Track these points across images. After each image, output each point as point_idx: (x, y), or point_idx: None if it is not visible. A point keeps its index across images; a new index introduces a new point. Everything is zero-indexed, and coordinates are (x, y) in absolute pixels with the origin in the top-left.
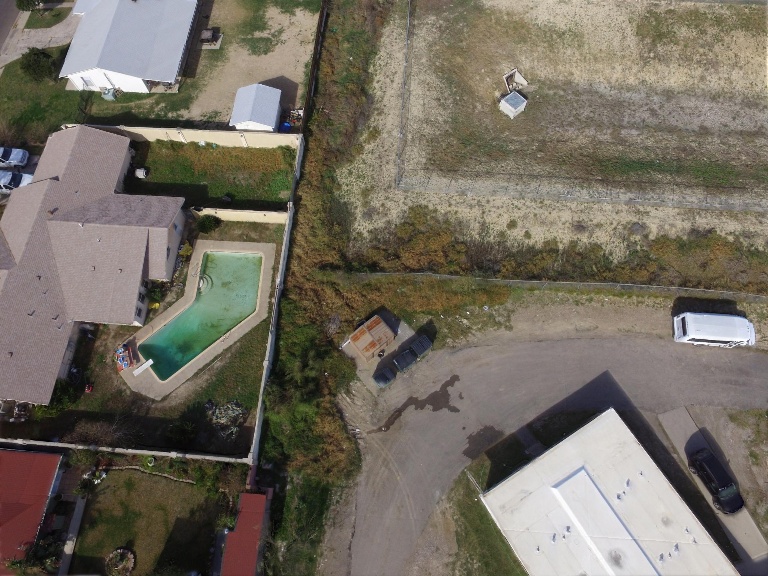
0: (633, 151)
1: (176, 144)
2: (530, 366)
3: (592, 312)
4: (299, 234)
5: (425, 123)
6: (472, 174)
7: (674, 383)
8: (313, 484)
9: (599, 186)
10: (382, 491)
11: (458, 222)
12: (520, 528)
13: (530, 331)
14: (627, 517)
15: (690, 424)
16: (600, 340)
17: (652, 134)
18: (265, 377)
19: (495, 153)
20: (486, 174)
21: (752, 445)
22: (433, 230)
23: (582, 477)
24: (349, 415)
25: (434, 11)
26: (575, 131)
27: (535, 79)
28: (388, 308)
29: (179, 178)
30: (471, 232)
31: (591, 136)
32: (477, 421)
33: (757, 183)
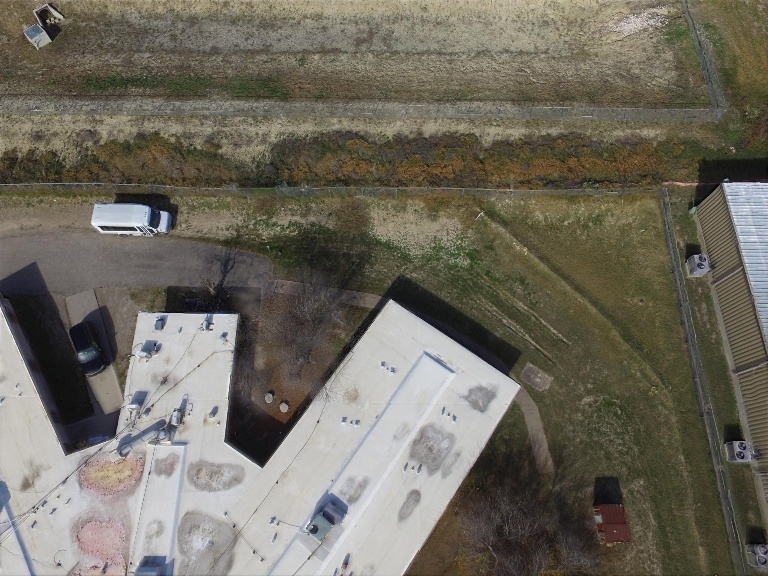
0: (129, 71)
1: None
2: None
3: (40, 212)
4: None
5: None
6: None
7: (92, 270)
8: None
9: (67, 100)
10: None
11: None
12: None
13: None
14: None
15: (92, 304)
16: (39, 236)
17: (162, 56)
18: None
19: None
20: None
21: None
22: None
23: None
24: None
25: None
26: (91, 57)
27: (71, 13)
28: None
29: None
30: None
31: (104, 61)
32: None
33: (220, 91)
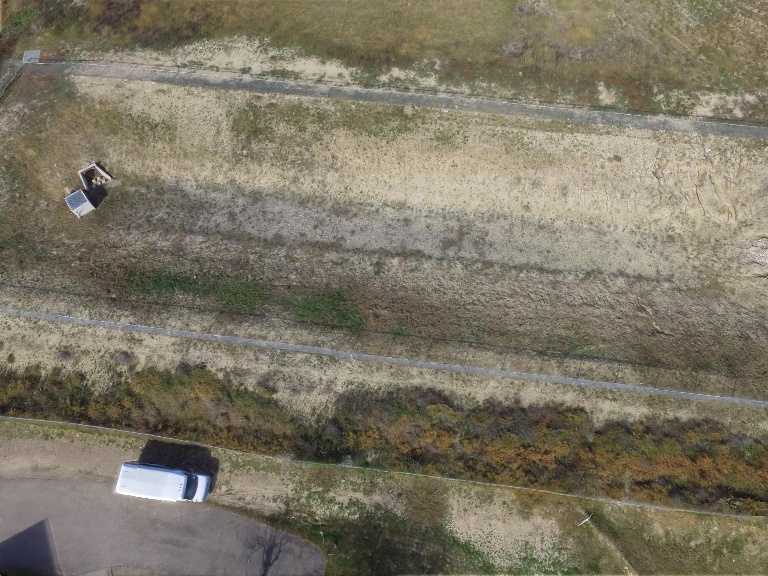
0: (179, 263)
1: None
2: None
3: (59, 449)
4: None
5: None
6: None
7: (111, 539)
8: None
9: (104, 307)
10: None
11: None
12: None
13: None
14: None
15: None
16: (55, 482)
17: (217, 242)
18: None
19: (29, 260)
20: None
21: None
22: None
23: None
24: None
25: (25, 97)
26: (137, 235)
27: (121, 174)
28: None
29: None
30: None
31: (151, 242)
32: None
33: (281, 310)
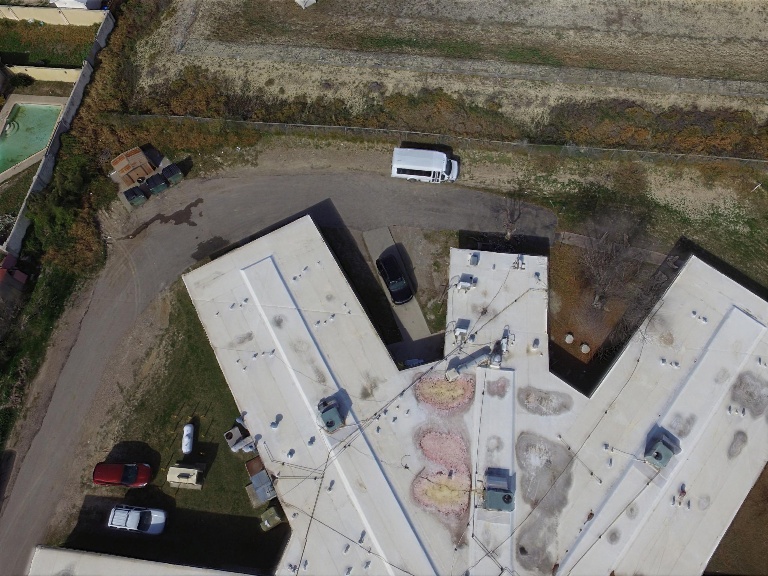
0: (398, 33)
1: (10, 21)
2: (265, 193)
3: (328, 154)
4: (93, 89)
5: (217, 5)
6: (246, 44)
7: (384, 209)
8: (60, 273)
9: (351, 54)
10: (117, 282)
11: (224, 79)
12: (207, 298)
13: (272, 167)
14: (298, 293)
15: (388, 240)
16: (330, 176)
17: (422, 22)
18: (32, 188)
19: (275, 31)
20: (258, 44)
21: (438, 257)
22: (201, 84)
23: (267, 262)
24: (105, 226)
25: None
26: (355, 19)
27: None
28: (154, 145)
29: (8, 48)
30: (235, 88)
31: (368, 23)
32: (209, 233)
33: (493, 56)
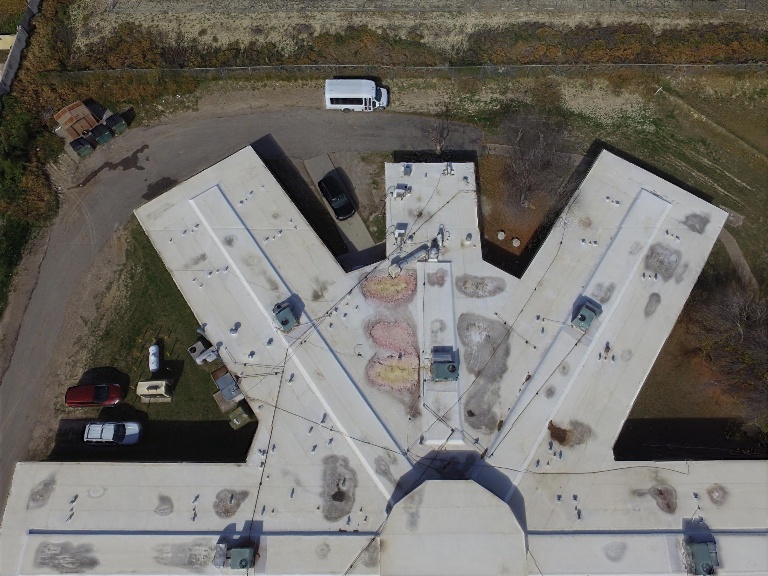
0: None
1: None
2: (208, 135)
3: (265, 94)
4: (30, 53)
5: None
6: None
7: (322, 139)
8: (14, 224)
9: (278, 0)
10: (72, 227)
11: (159, 33)
12: (159, 228)
13: (212, 111)
14: (245, 215)
15: (329, 165)
16: (268, 114)
17: None
18: None
19: None
20: None
21: (376, 176)
22: (136, 39)
23: (214, 190)
24: (55, 178)
25: None
26: None
27: None
28: (95, 100)
29: None
30: (169, 40)
31: None
32: (157, 175)
33: None
